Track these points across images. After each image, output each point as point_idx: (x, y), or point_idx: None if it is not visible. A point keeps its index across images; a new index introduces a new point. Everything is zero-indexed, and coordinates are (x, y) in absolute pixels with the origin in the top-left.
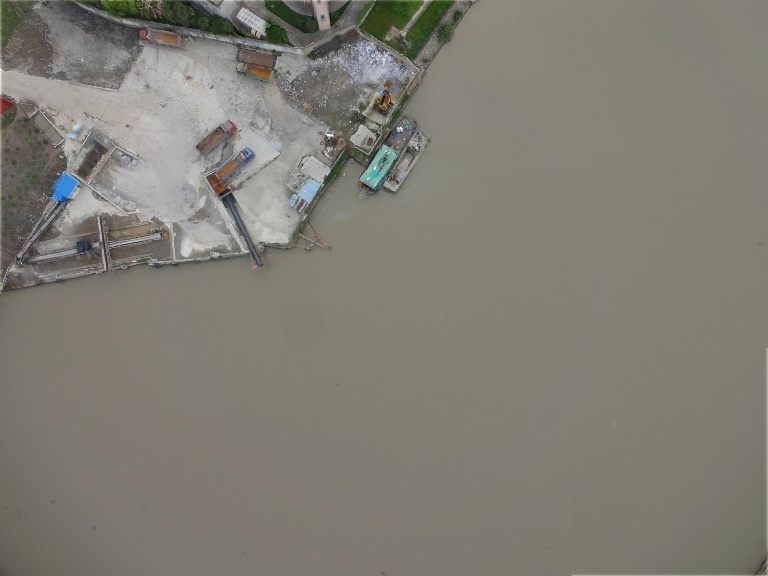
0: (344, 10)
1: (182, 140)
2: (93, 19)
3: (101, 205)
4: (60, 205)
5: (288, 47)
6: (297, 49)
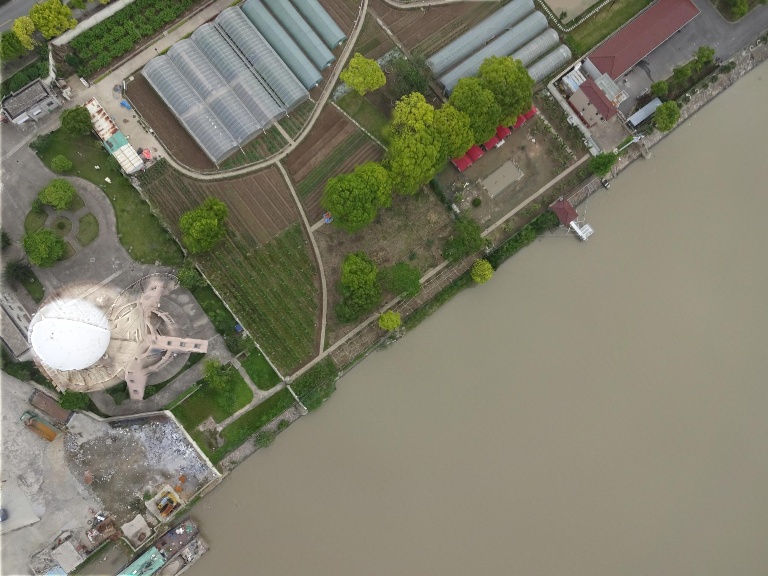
0: (163, 387)
1: None
2: None
3: None
4: None
5: (84, 415)
6: (94, 420)
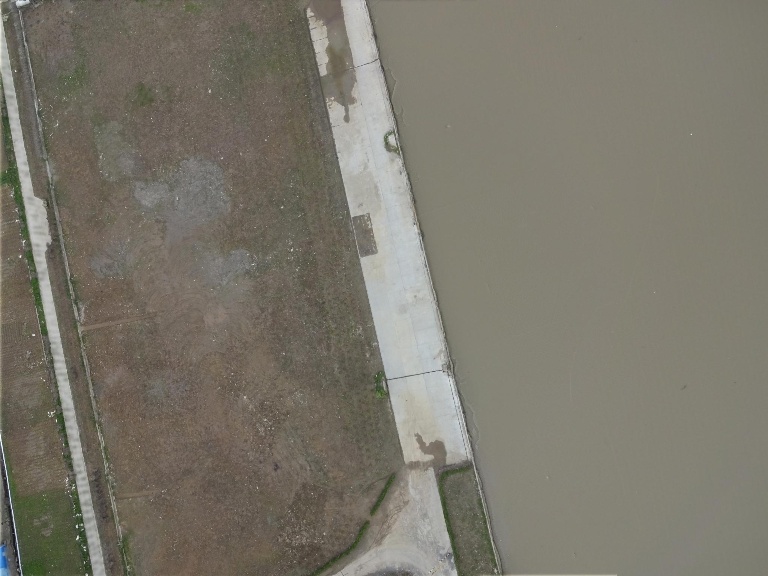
0: None
1: None
2: None
3: None
4: None
5: None
6: None
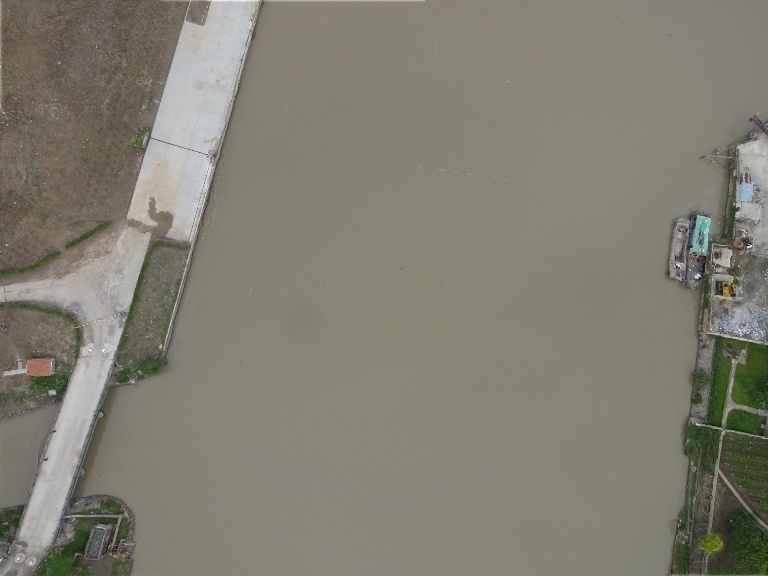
0: None
1: None
2: None
3: None
4: None
5: None
6: None
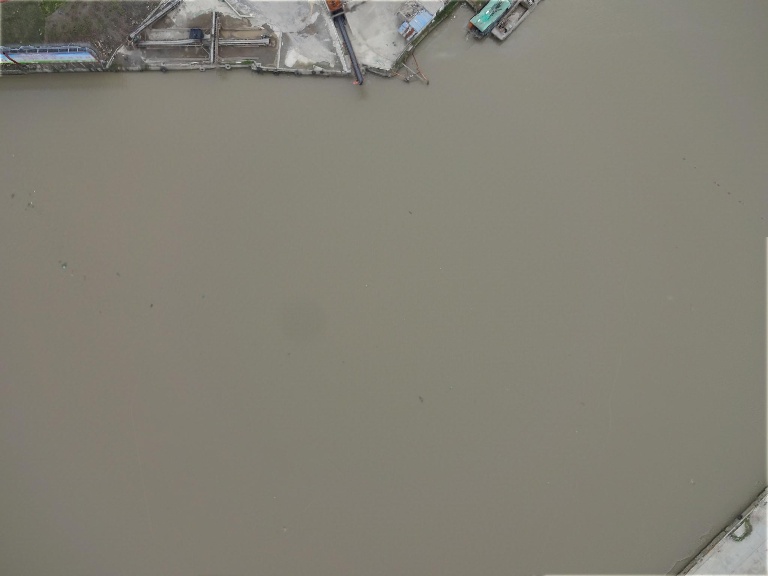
0: None
1: None
2: None
3: (217, 4)
4: None
5: None
6: None
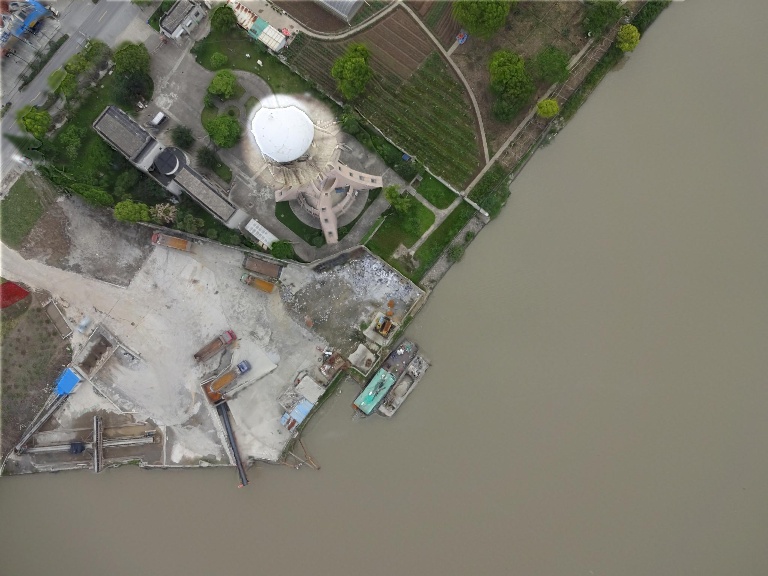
0: (353, 226)
1: (183, 343)
2: (111, 215)
3: (100, 401)
4: (62, 396)
5: None
6: (302, 265)
